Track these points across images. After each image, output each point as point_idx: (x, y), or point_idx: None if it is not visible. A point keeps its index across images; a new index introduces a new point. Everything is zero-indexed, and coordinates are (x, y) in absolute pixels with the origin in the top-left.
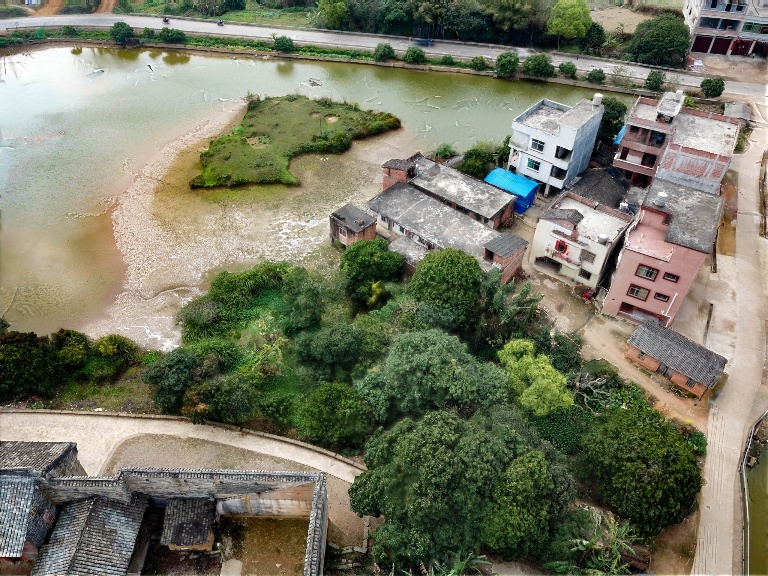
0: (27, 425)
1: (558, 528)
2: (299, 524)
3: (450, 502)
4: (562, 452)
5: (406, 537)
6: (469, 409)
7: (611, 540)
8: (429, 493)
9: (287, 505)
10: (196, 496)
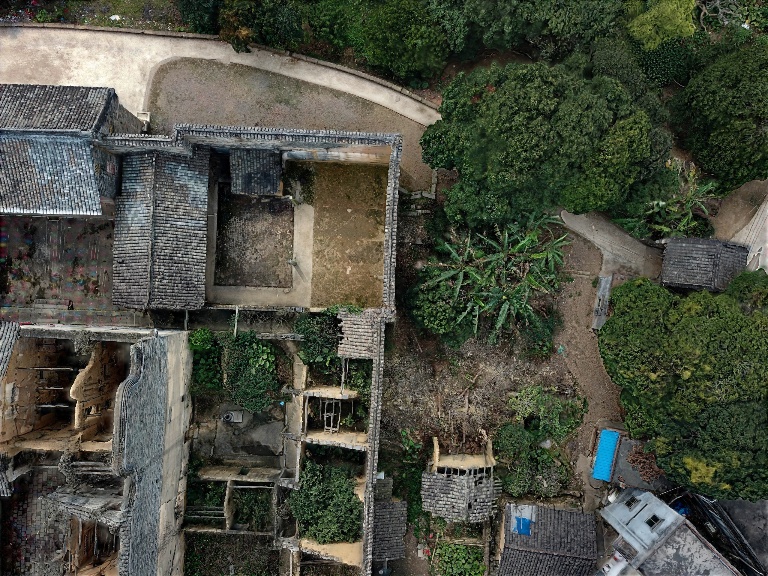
0: (41, 44)
1: (638, 190)
2: (367, 170)
3: (535, 174)
4: (656, 85)
5: (483, 201)
6: (567, 47)
7: (686, 197)
8: (515, 165)
9: (355, 156)
10: (259, 148)
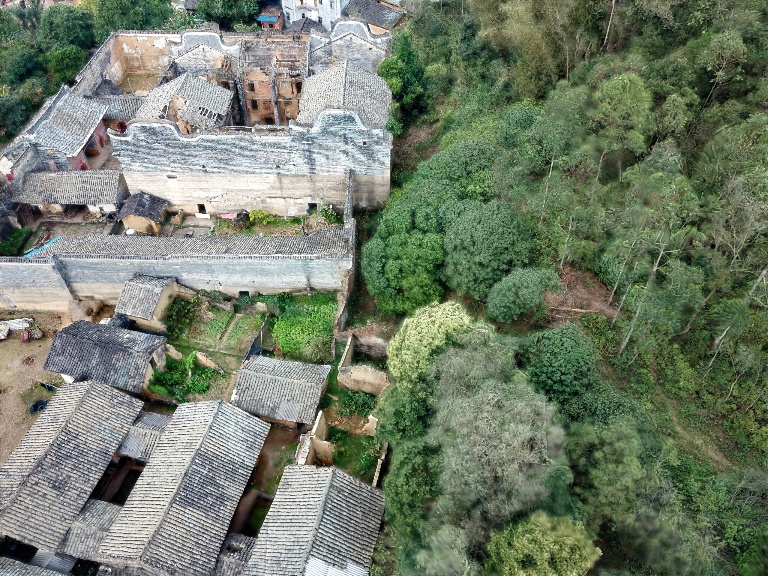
0: None
1: None
2: (126, 78)
3: None
4: None
5: None
6: None
7: None
8: (137, 8)
9: (117, 69)
10: (99, 83)
